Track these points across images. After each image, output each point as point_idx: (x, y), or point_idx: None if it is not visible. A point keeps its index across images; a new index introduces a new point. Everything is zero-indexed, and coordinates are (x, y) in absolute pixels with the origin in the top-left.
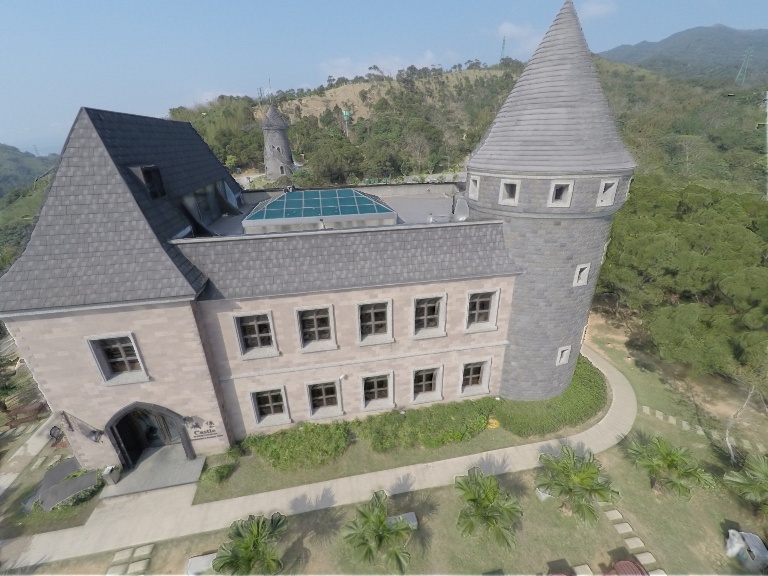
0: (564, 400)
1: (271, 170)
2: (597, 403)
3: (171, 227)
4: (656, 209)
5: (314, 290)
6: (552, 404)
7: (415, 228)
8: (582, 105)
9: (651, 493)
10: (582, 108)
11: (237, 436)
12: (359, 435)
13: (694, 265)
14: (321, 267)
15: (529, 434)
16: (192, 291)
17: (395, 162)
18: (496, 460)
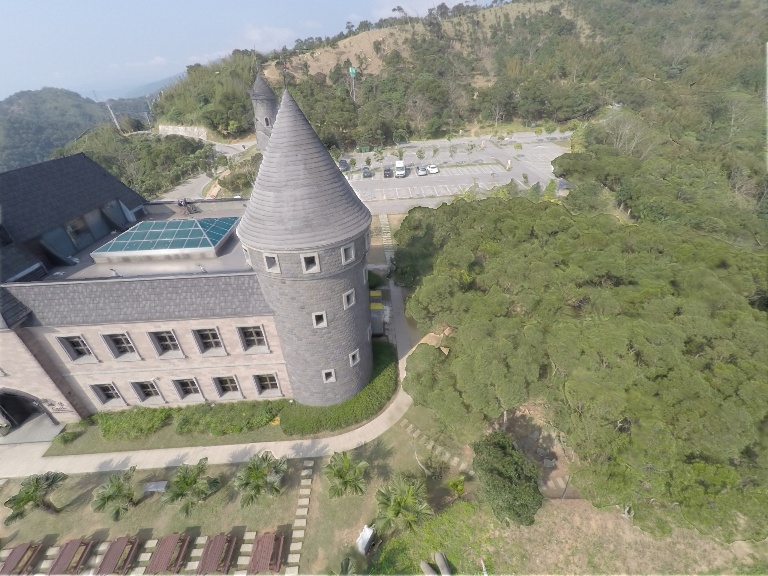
0: (340, 408)
1: (261, 140)
2: (363, 414)
3: (10, 270)
4: (516, 230)
5: (106, 322)
6: (327, 410)
7: (181, 278)
8: (287, 191)
9: None
10: (286, 193)
11: (92, 411)
12: (175, 419)
13: (461, 307)
14: (112, 305)
15: (292, 433)
16: (5, 325)
17: (389, 129)
18: (254, 450)
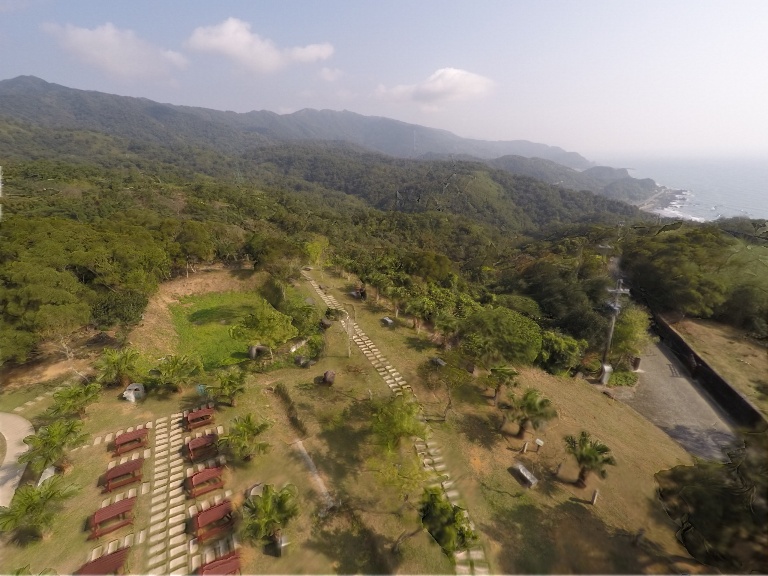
0: None
1: None
2: None
3: None
4: None
5: None
6: None
7: None
8: None
9: None
10: None
11: None
12: None
13: None
14: None
15: None
16: None
17: None
18: None
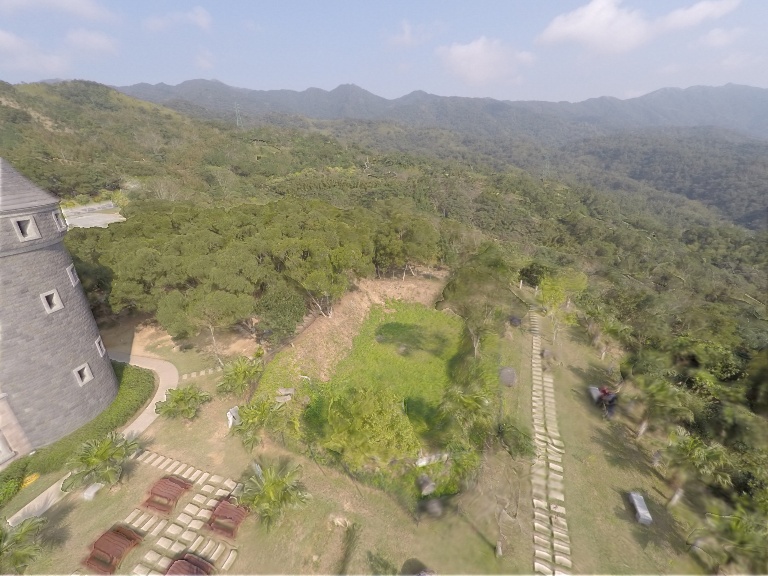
0: (111, 410)
1: None
2: (142, 394)
3: None
4: (158, 230)
5: None
6: (98, 420)
7: None
8: None
9: (186, 427)
10: None
11: None
12: None
13: (173, 265)
14: None
15: None
16: None
17: None
18: (36, 506)
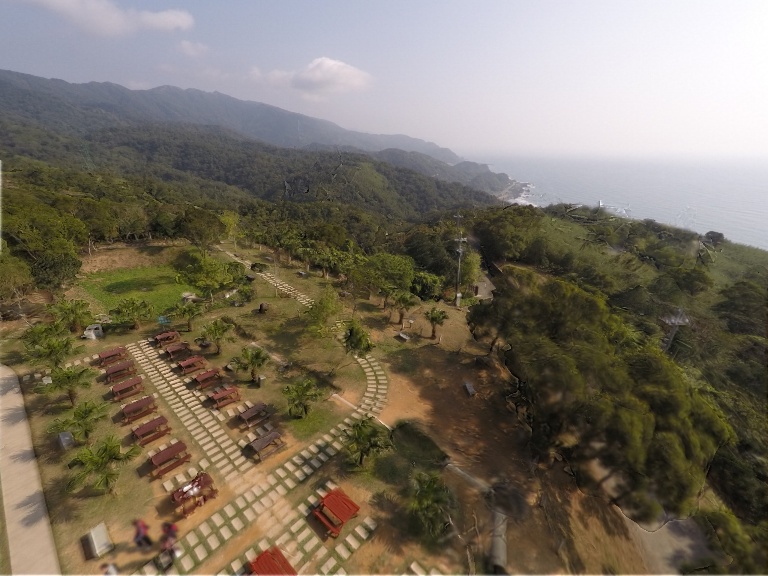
0: None
1: None
2: None
3: None
4: None
5: None
6: None
7: None
8: None
9: None
10: None
11: None
12: None
13: None
14: None
15: None
16: None
17: None
18: (8, 412)
